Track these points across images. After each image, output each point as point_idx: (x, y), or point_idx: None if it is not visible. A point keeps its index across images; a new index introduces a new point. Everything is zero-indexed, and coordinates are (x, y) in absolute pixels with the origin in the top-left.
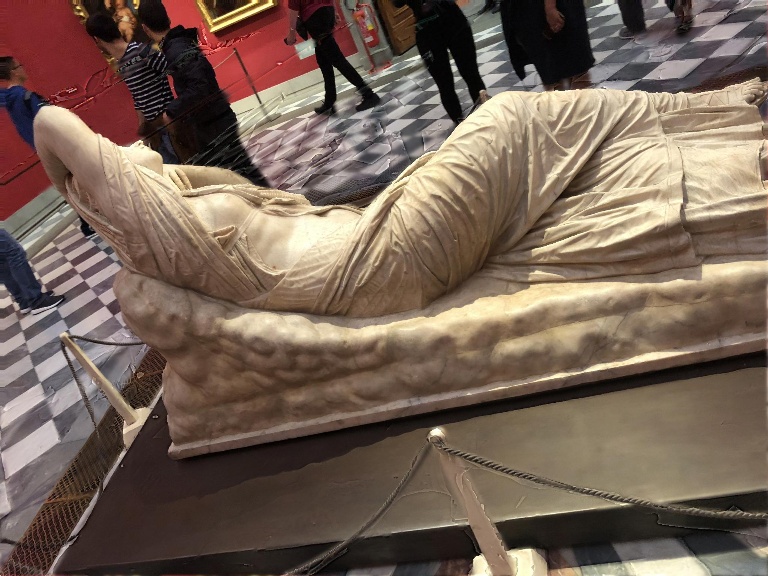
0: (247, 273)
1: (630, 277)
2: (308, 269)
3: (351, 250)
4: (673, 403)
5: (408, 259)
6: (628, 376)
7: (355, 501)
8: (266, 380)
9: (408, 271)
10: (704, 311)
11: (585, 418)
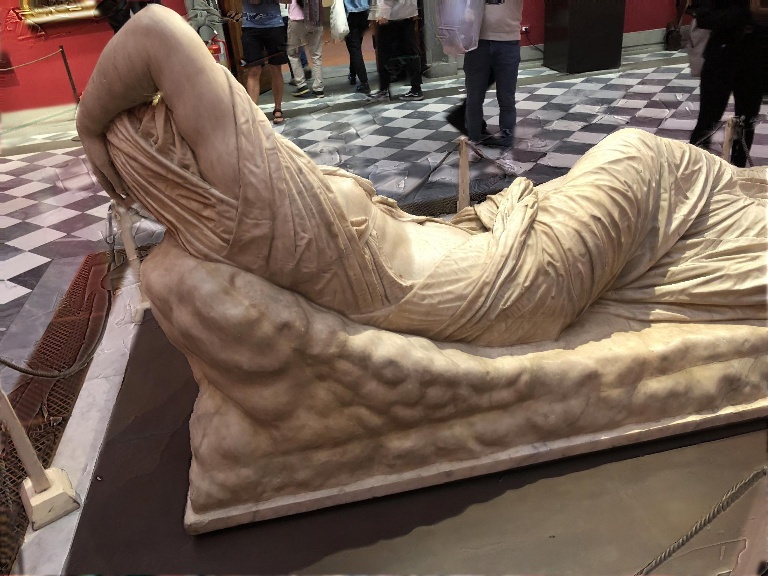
0: (375, 279)
1: (755, 321)
2: (445, 282)
3: (501, 265)
4: None
5: (560, 282)
6: (751, 419)
7: (513, 569)
8: (375, 418)
9: (555, 296)
10: None
11: (728, 461)
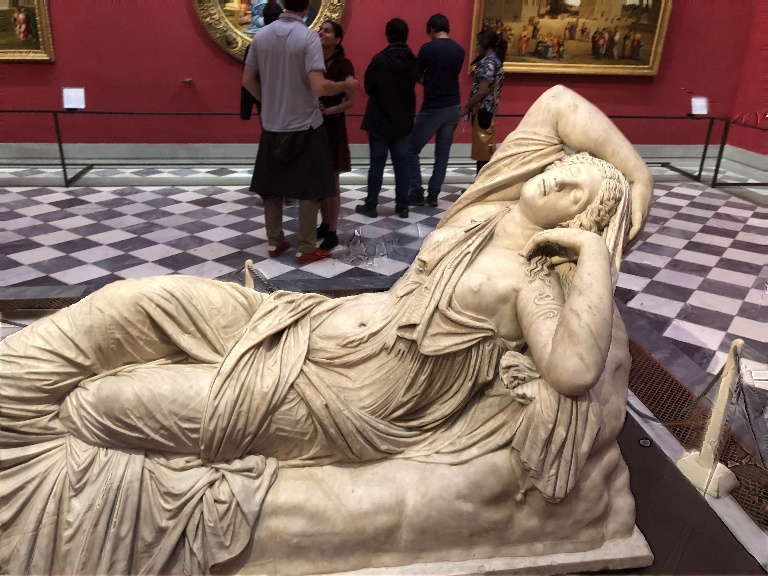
0: None
1: None
2: None
3: None
4: None
5: None
6: None
7: None
8: None
9: None
10: None
11: None
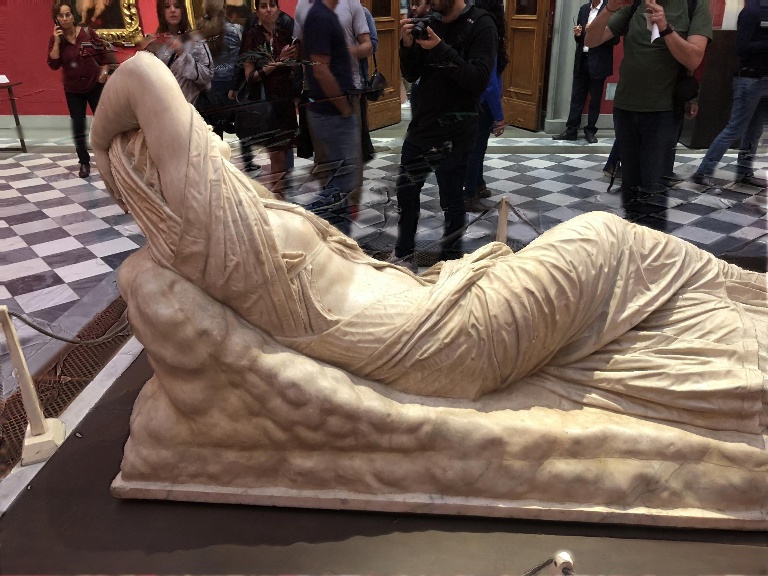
0: (301, 308)
1: (691, 427)
2: (369, 324)
3: (424, 318)
4: (713, 567)
5: (481, 345)
6: (667, 527)
7: None
8: (279, 433)
9: (475, 358)
10: (760, 481)
11: (623, 562)
